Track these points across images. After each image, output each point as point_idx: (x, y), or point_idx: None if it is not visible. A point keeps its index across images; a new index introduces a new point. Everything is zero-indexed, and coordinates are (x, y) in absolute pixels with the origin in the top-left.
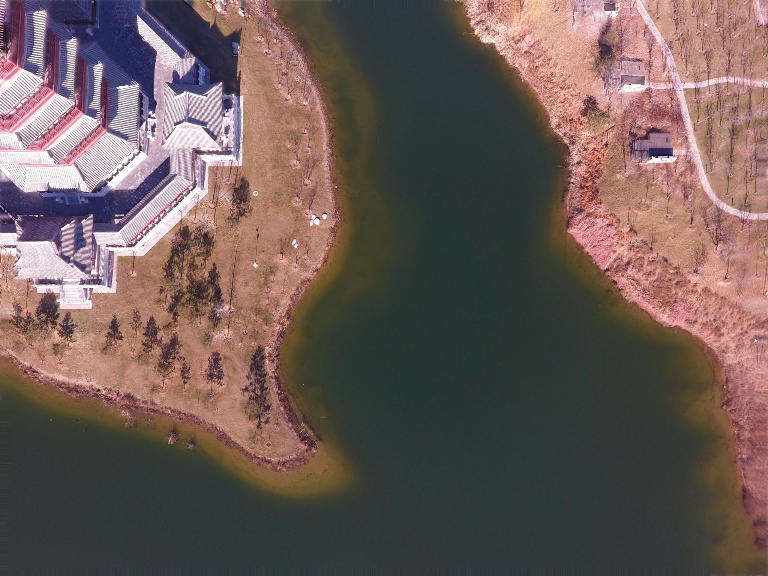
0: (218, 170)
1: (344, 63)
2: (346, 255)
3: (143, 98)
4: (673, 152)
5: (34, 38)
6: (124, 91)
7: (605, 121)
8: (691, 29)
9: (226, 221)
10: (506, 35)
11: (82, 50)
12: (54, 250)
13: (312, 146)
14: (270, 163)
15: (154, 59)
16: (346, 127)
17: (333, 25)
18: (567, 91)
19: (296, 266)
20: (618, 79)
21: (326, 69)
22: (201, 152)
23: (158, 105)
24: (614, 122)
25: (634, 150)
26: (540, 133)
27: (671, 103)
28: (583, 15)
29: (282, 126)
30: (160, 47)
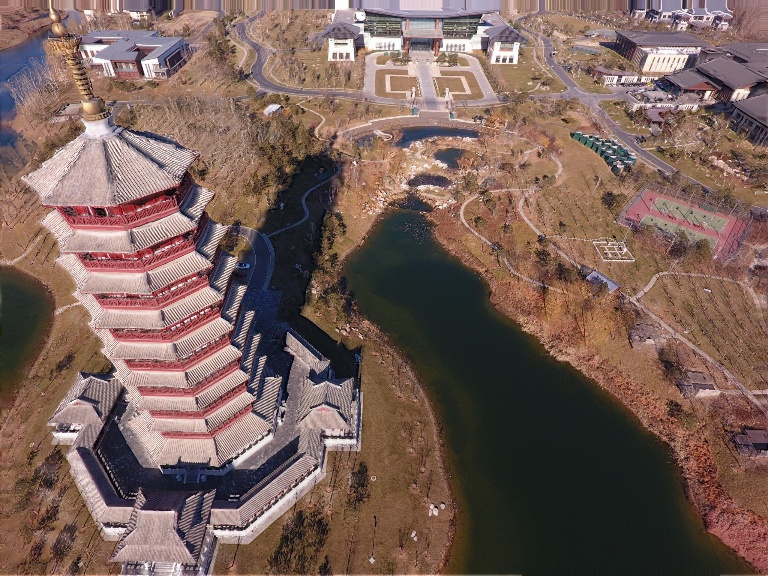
0: (337, 454)
1: (444, 373)
2: (469, 554)
3: (279, 390)
4: None
5: (242, 327)
6: (270, 381)
7: (695, 420)
8: (731, 352)
9: (342, 506)
10: (577, 356)
11: None
12: (174, 522)
13: (424, 437)
14: (387, 449)
15: (291, 363)
16: (452, 422)
17: (432, 347)
18: (647, 396)
19: (417, 564)
20: (690, 386)
21: (430, 377)
22: (325, 436)
23: (290, 396)
24: (704, 421)
25: (738, 444)
26: (635, 432)
27: (749, 405)
28: (641, 340)
29: (397, 418)
30: (302, 353)
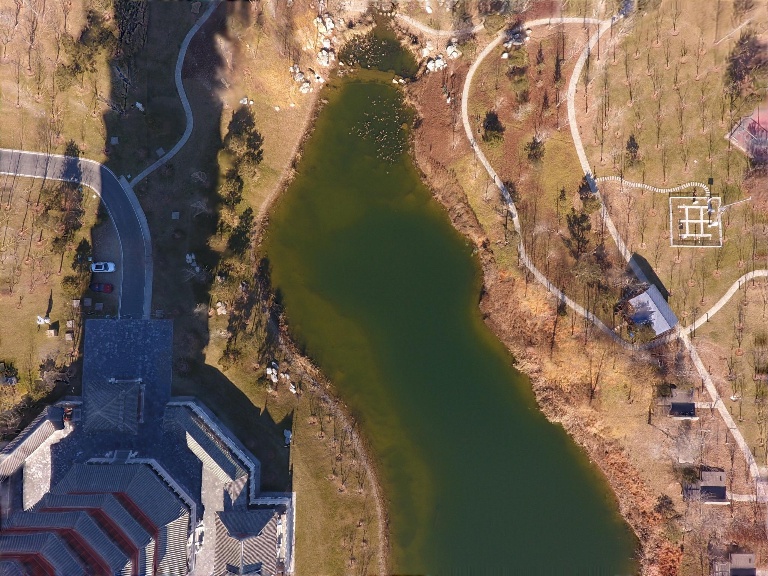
0: None
1: (400, 435)
2: None
3: (191, 511)
4: (756, 573)
5: None
6: (173, 525)
7: (681, 524)
8: None
9: None
10: (574, 415)
11: (133, 522)
12: None
13: (367, 539)
14: (324, 567)
15: None
16: (402, 508)
17: (389, 392)
18: (640, 485)
19: None
20: (698, 490)
21: (381, 443)
22: None
23: (206, 511)
24: None
25: (714, 571)
26: None
27: (754, 518)
28: None
29: (336, 523)
30: (210, 464)
